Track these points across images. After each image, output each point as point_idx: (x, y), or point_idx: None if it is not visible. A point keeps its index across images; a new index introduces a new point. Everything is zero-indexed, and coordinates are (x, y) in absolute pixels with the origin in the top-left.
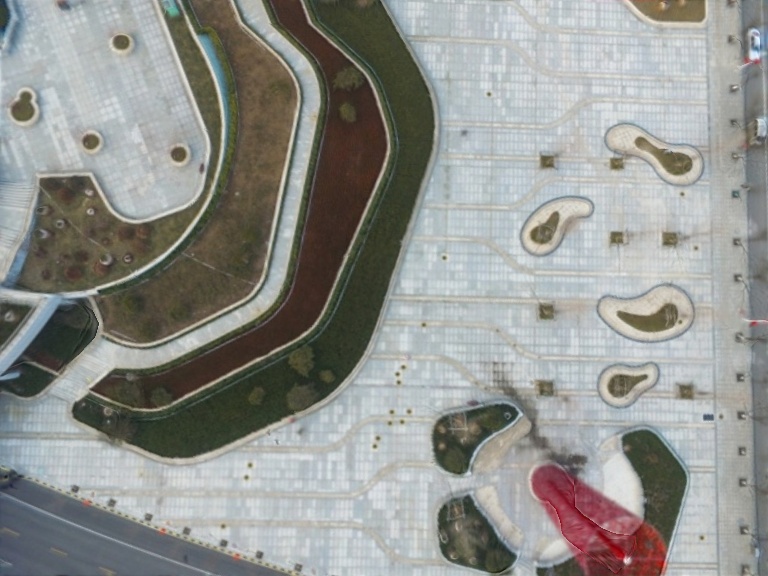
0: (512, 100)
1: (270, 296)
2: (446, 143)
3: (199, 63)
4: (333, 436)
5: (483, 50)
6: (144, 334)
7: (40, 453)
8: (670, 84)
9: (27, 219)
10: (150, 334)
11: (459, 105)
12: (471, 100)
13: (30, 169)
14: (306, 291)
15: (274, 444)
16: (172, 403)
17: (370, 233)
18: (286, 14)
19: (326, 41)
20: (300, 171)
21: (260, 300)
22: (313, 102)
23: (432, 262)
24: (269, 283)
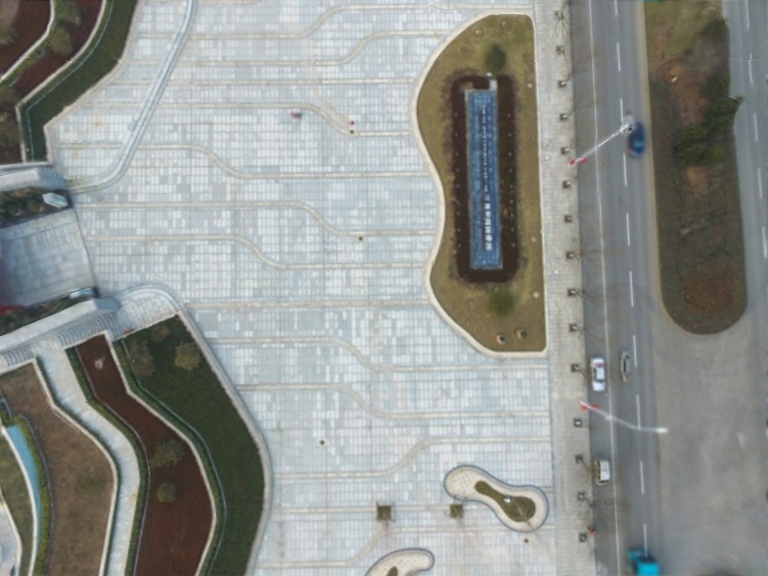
0: (346, 447)
1: None
2: (279, 497)
3: (8, 458)
4: None
5: (315, 395)
6: None
7: None
8: (511, 420)
9: None
10: None
11: (291, 456)
12: (304, 450)
13: None
14: None
15: None
16: None
17: None
18: (103, 386)
19: (146, 410)
20: (120, 554)
21: None
22: (132, 481)
23: None
24: None
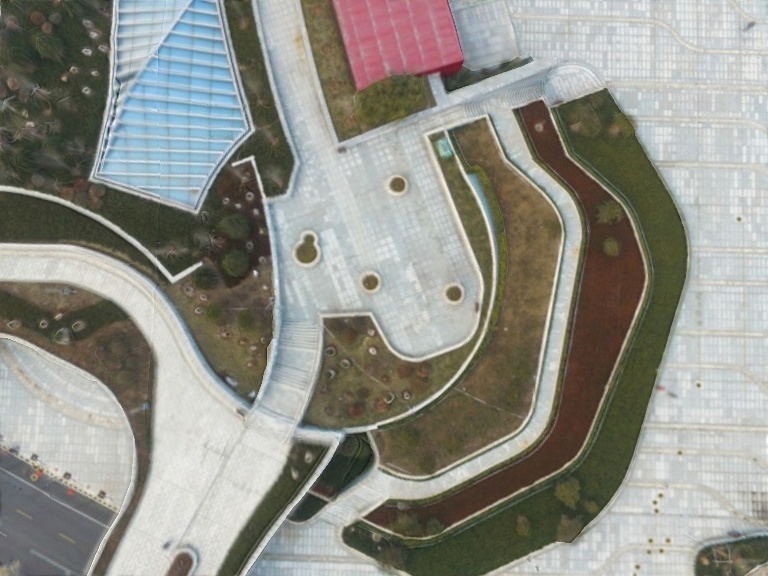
0: (763, 225)
1: (537, 429)
2: (697, 269)
3: (470, 202)
4: (593, 564)
5: (732, 174)
6: (420, 468)
7: (311, 575)
8: None
9: (316, 360)
10: (427, 468)
11: (709, 230)
12: (721, 225)
13: (312, 308)
14: (570, 423)
15: (535, 571)
16: (441, 532)
17: (628, 363)
18: (545, 147)
19: (583, 173)
20: (564, 304)
21: (527, 433)
22: (575, 236)
23: (686, 389)
24: (536, 416)
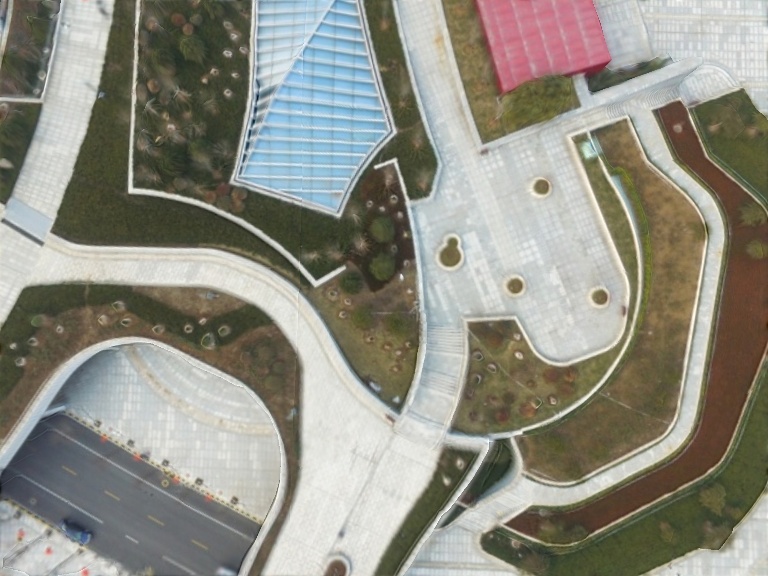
0: None
1: (682, 434)
2: None
3: (614, 205)
4: (735, 571)
5: None
6: (565, 474)
7: None
8: None
9: (463, 364)
10: (573, 474)
11: None
12: None
13: (454, 312)
14: (713, 428)
15: None
16: (584, 539)
17: None
18: (684, 149)
19: (723, 174)
20: (707, 308)
21: (672, 438)
22: (718, 238)
23: None
24: (681, 421)
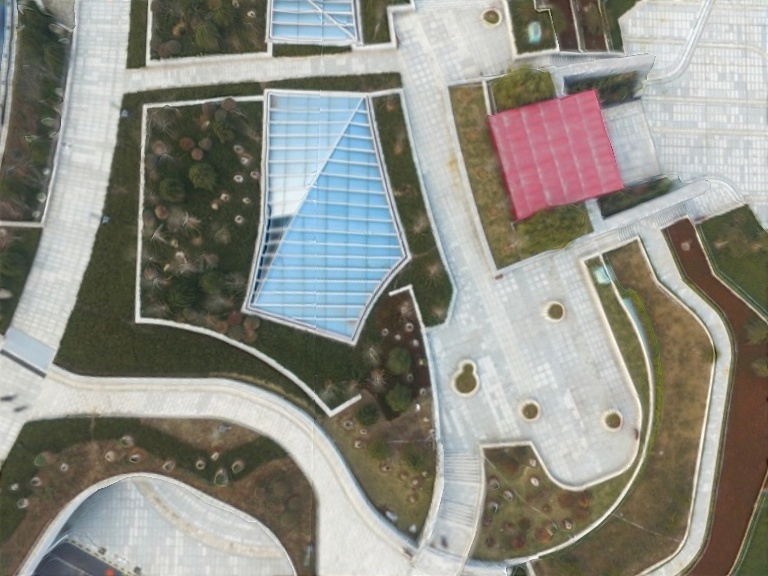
0: None
1: (692, 551)
2: None
3: (626, 328)
4: None
5: None
6: None
7: None
8: None
9: (479, 493)
10: None
11: None
12: None
13: (470, 438)
14: (722, 543)
15: None
16: None
17: None
18: (692, 267)
19: (729, 292)
20: (715, 425)
21: (682, 555)
22: (725, 356)
23: None
24: (691, 538)
